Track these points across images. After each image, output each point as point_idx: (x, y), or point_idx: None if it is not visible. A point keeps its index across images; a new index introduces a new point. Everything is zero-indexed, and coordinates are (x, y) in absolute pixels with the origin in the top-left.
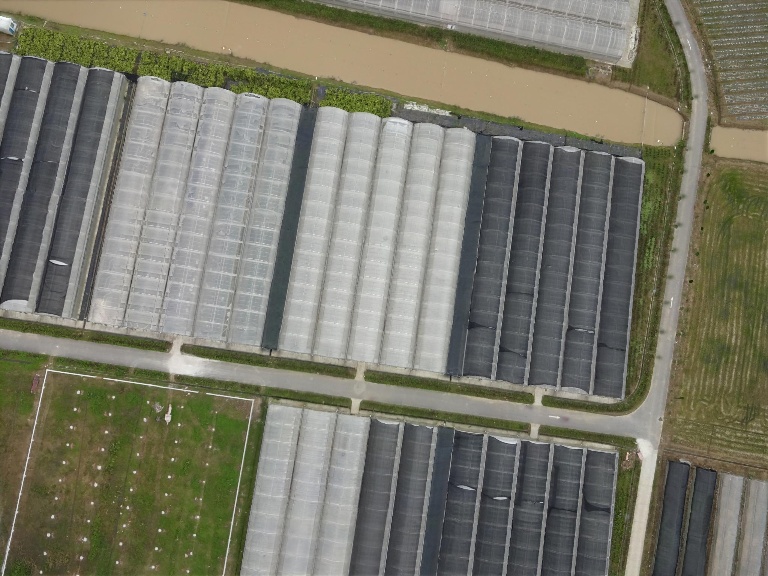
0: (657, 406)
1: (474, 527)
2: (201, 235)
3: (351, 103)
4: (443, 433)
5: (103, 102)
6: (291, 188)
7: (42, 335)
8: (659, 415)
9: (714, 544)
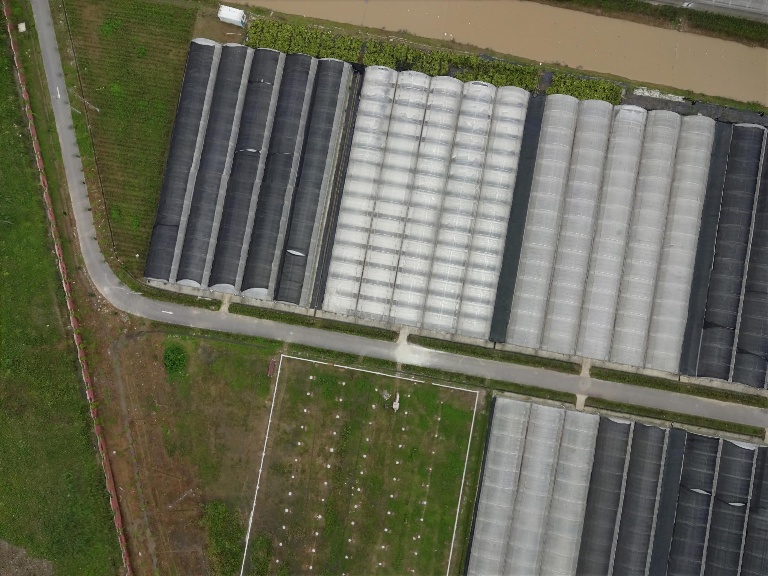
0: None
1: (707, 531)
2: (430, 227)
3: (579, 90)
4: (674, 434)
5: (334, 93)
6: (516, 179)
7: (277, 322)
8: None
9: None
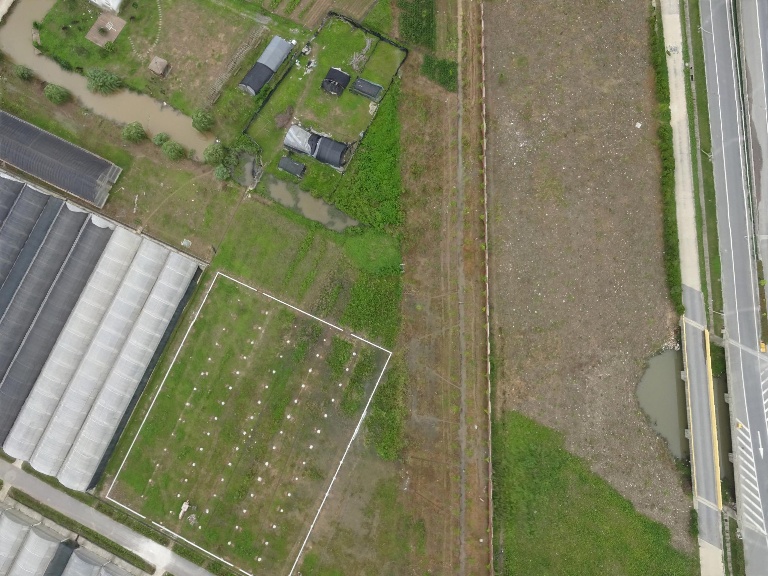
0: None
1: None
2: None
3: None
4: None
5: None
6: None
7: None
8: None
9: None
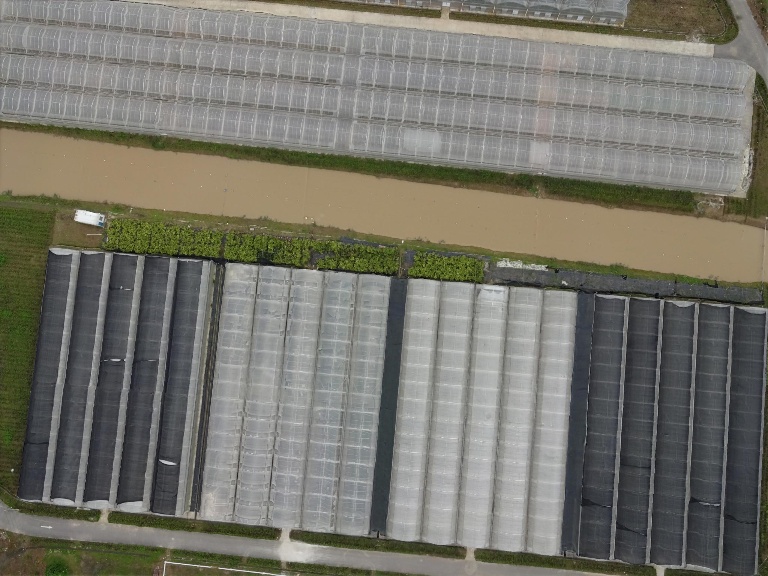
0: None
1: None
2: (301, 424)
3: (441, 268)
4: None
5: (195, 294)
6: (386, 363)
7: (158, 528)
8: None
9: None
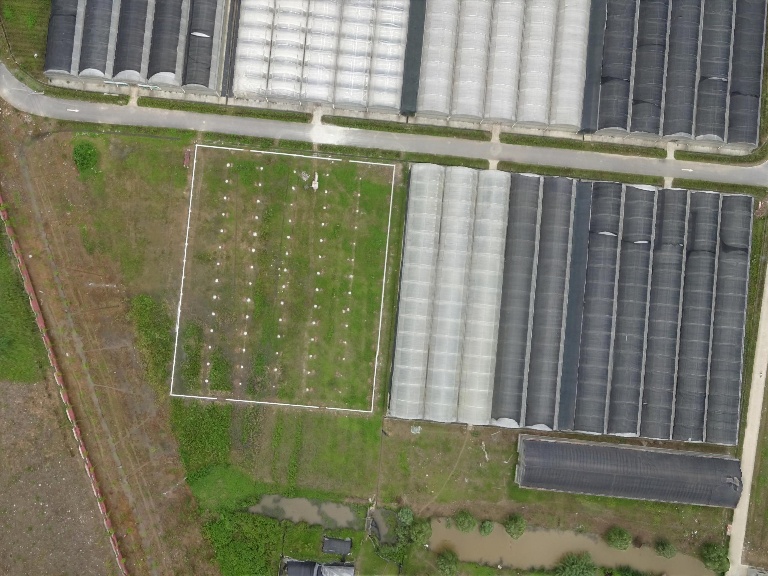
0: None
1: (617, 271)
2: (334, 2)
3: None
4: (581, 186)
5: None
6: None
7: (188, 112)
8: None
9: None
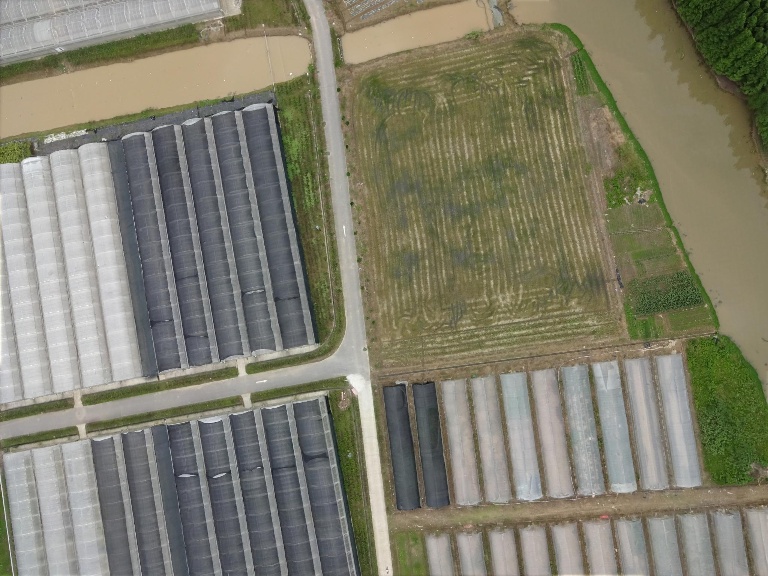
0: (358, 338)
1: (206, 509)
2: None
3: None
4: (158, 431)
5: None
6: None
7: None
8: (362, 346)
9: (451, 454)
